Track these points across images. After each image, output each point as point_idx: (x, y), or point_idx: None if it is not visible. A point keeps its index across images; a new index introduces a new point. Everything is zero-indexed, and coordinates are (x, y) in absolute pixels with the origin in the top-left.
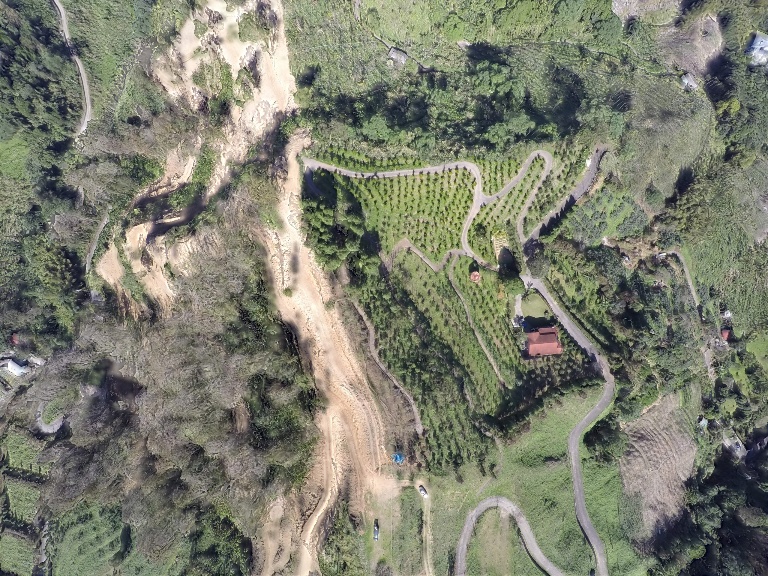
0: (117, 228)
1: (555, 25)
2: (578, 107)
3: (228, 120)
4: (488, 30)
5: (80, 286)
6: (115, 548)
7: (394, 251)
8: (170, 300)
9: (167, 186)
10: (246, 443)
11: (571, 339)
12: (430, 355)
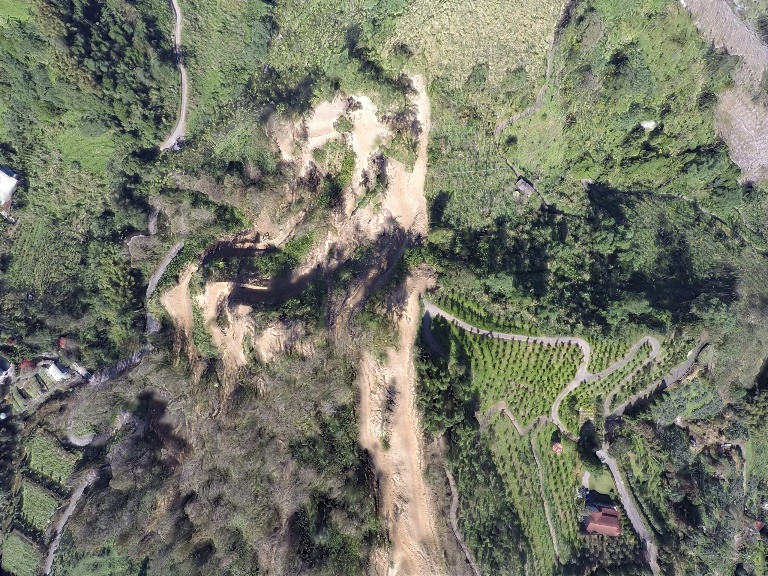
0: (198, 276)
1: (677, 179)
2: (695, 298)
3: (340, 208)
4: None
5: (138, 307)
6: None
7: (489, 412)
8: (238, 368)
9: (255, 243)
10: (297, 556)
11: (629, 522)
12: (504, 530)
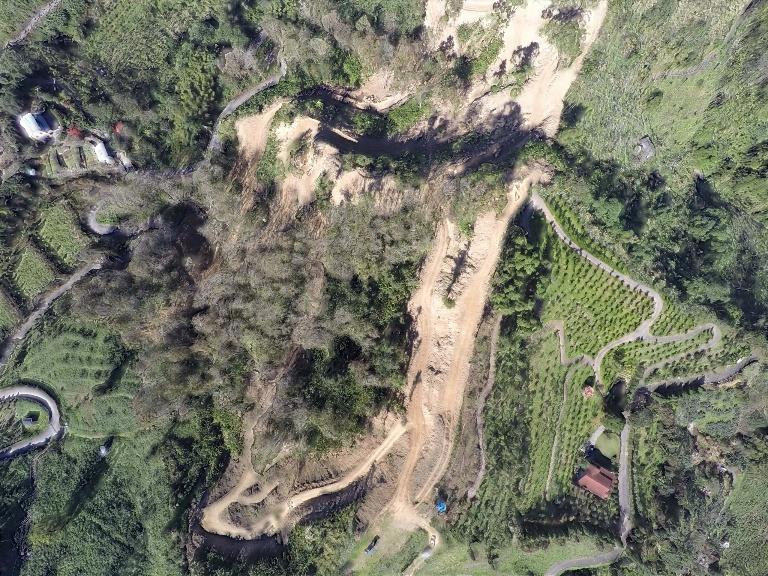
0: (291, 106)
1: None
2: None
3: (465, 91)
4: (723, 176)
5: (208, 123)
6: (101, 378)
7: (547, 325)
8: (298, 206)
9: (357, 100)
10: (302, 390)
11: (617, 492)
12: None
